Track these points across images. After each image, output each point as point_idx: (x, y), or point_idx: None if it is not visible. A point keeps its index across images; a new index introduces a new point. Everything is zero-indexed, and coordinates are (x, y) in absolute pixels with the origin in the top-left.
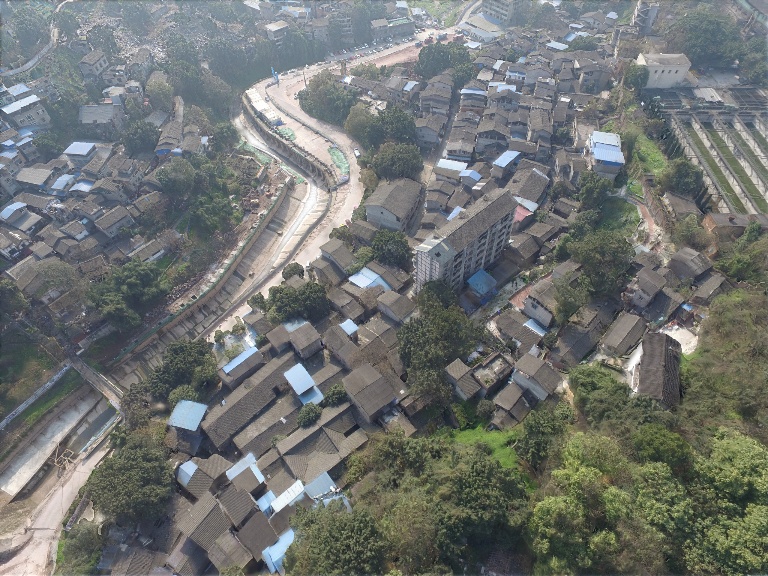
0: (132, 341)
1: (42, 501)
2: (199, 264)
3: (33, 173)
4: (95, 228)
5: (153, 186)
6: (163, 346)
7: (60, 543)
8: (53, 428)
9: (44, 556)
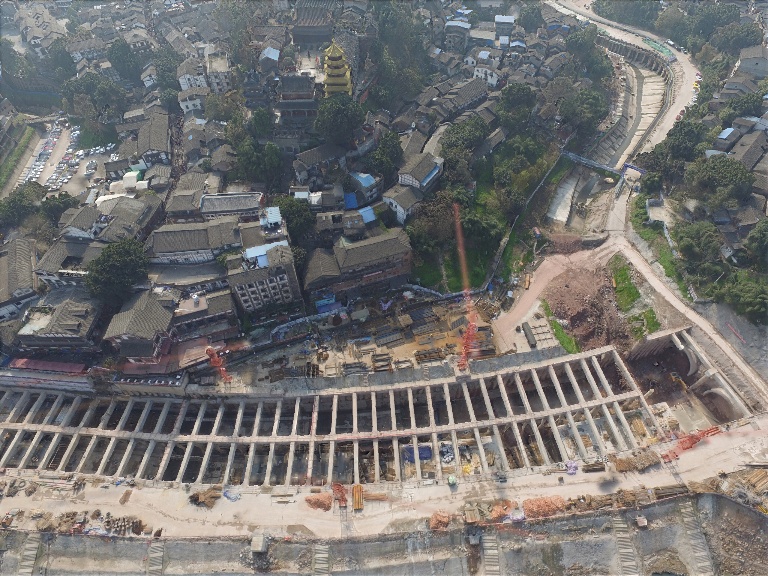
0: (586, 145)
1: (590, 223)
2: (605, 103)
3: (482, 33)
4: (538, 71)
5: (559, 49)
6: (600, 153)
7: (642, 231)
8: (560, 191)
9: (626, 242)
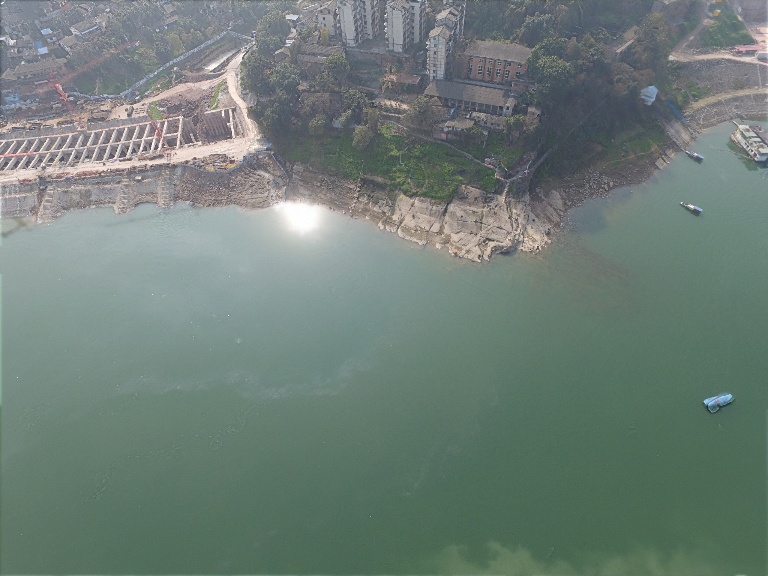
0: (252, 29)
1: None
2: None
3: None
4: None
5: None
6: None
7: (241, 65)
8: (221, 56)
9: (233, 74)
